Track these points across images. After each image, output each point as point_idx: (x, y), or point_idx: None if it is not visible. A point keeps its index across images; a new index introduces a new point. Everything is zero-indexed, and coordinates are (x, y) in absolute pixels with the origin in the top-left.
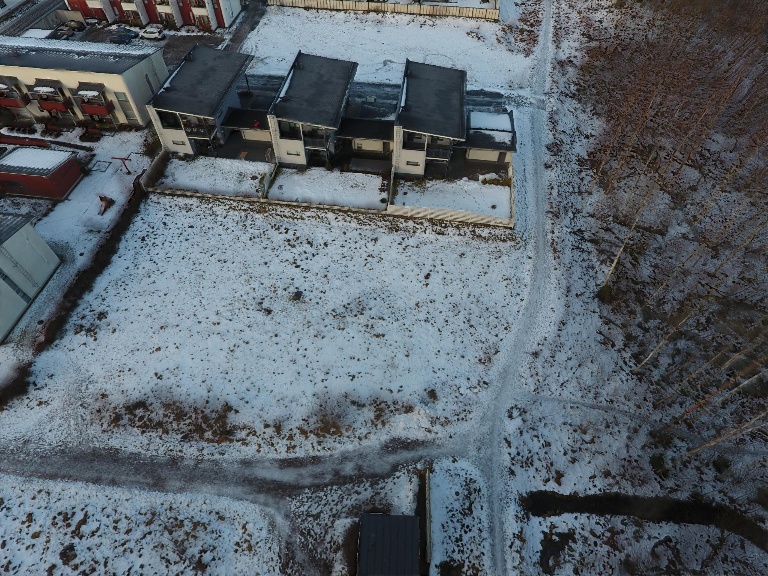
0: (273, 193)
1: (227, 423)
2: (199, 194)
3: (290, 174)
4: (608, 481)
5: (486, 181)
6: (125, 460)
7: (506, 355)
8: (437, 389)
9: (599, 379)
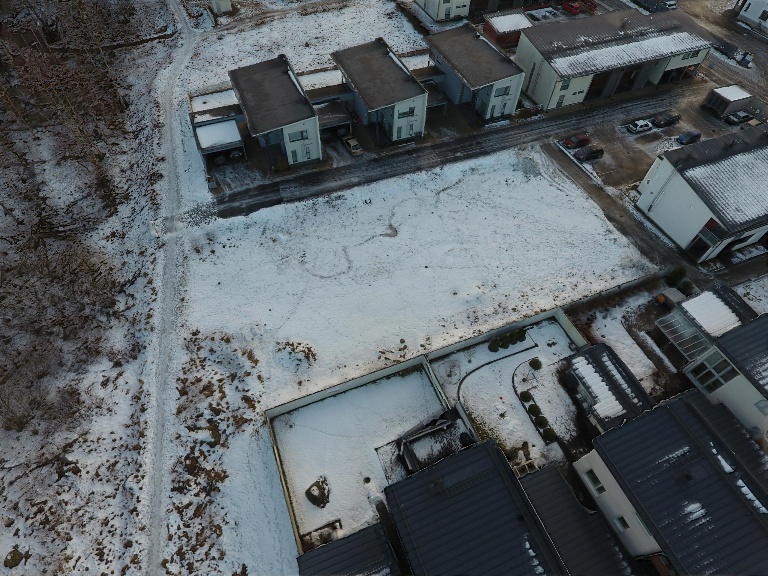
0: None
1: None
2: (407, 53)
3: None
4: None
5: None
6: (331, 3)
7: (186, 58)
8: None
9: None
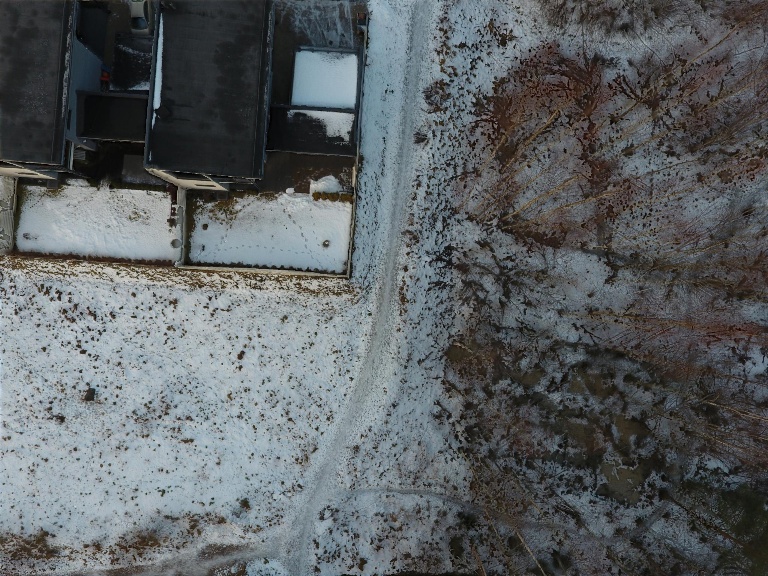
0: (22, 240)
1: (48, 545)
2: None
3: (39, 198)
4: (407, 562)
5: (318, 195)
6: None
7: (324, 453)
8: (250, 497)
9: (422, 462)
